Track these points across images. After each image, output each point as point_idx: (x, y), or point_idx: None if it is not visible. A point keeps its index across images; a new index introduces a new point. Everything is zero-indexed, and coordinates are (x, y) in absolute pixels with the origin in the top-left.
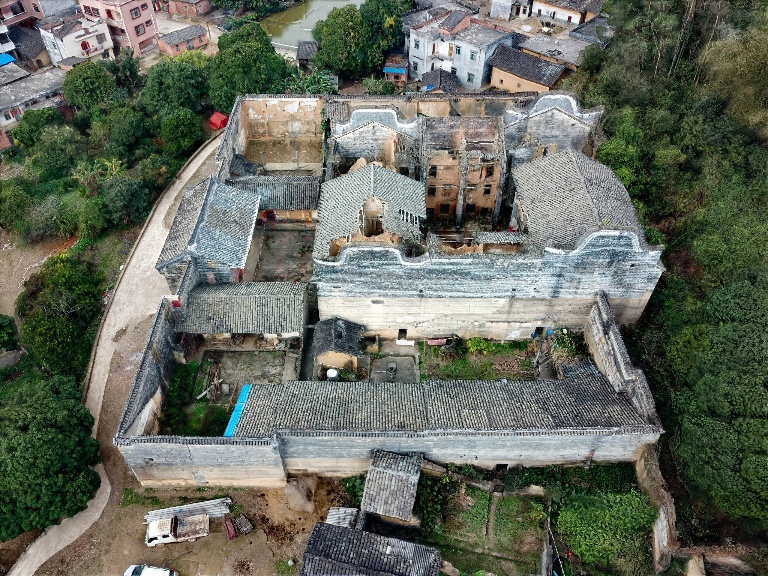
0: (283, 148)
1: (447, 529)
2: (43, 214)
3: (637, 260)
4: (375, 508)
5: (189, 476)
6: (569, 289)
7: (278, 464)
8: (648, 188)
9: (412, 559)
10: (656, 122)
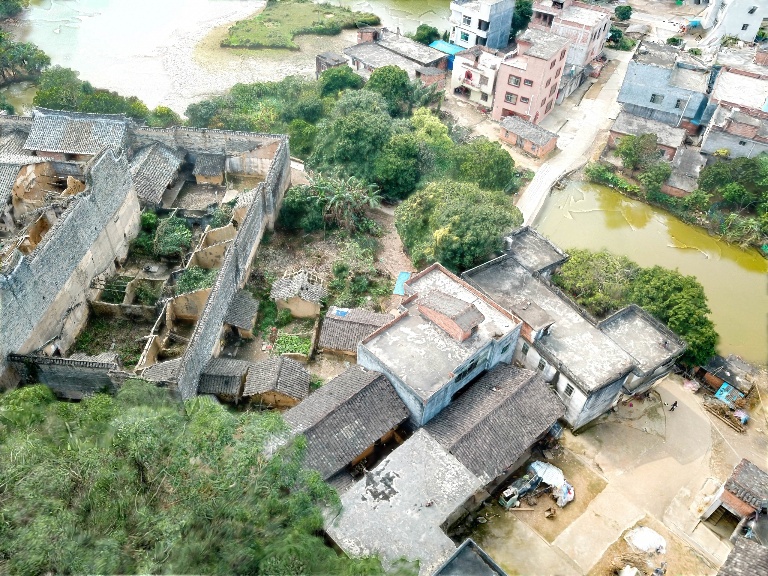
0: None
1: None
2: None
3: None
4: None
5: None
6: None
7: None
8: None
9: None
10: None
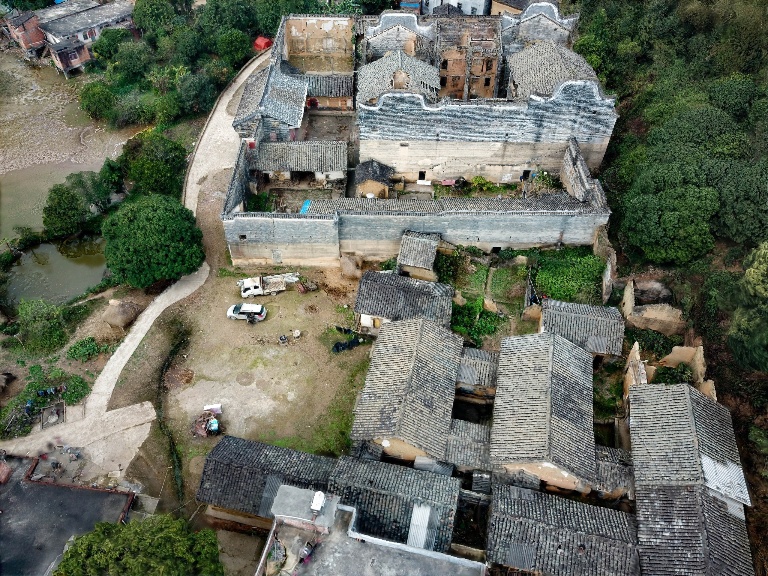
0: (319, 61)
1: (457, 286)
2: (127, 105)
3: (598, 107)
4: (407, 262)
5: (269, 255)
6: (548, 134)
7: (336, 241)
8: (613, 77)
9: (434, 287)
10: (620, 26)
